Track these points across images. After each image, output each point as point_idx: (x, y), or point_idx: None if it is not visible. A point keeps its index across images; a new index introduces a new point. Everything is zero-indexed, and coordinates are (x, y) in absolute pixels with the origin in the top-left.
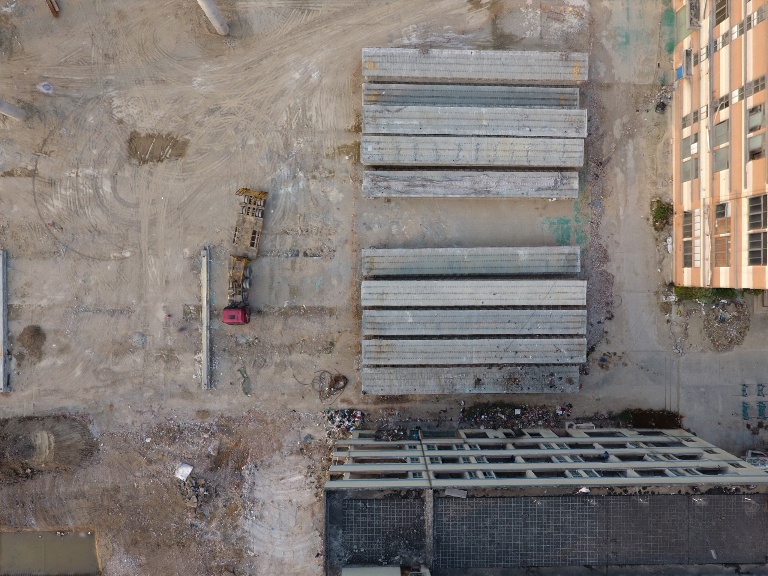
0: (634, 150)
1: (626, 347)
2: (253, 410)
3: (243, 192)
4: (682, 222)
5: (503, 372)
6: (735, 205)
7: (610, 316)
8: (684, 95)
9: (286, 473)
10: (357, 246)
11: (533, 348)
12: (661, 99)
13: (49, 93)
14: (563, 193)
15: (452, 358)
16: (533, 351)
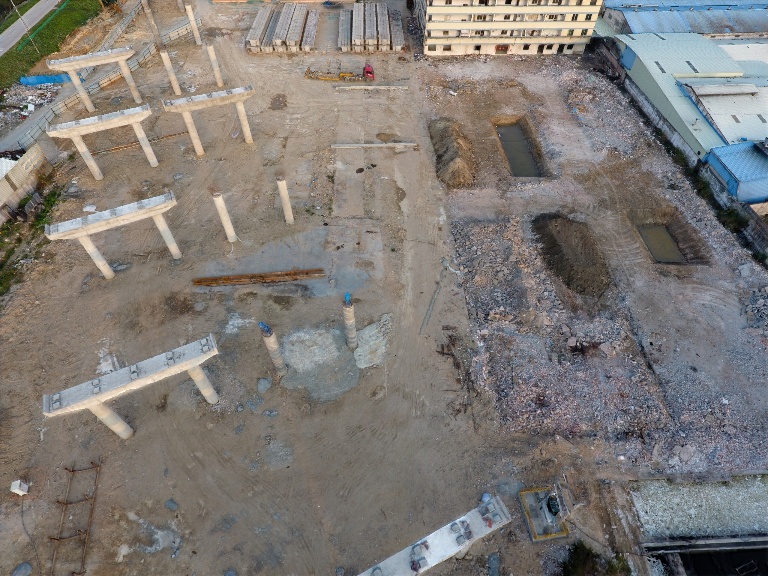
0: None
1: None
2: None
3: None
4: None
5: (392, 21)
6: None
7: None
8: None
9: (448, 70)
10: None
11: None
12: None
13: None
14: None
15: None
16: None
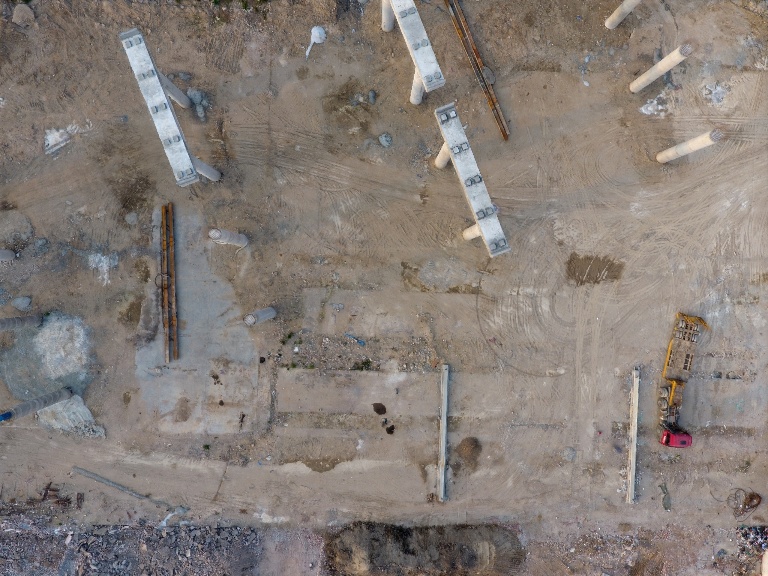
0: None
1: None
2: (671, 524)
3: None
4: None
5: None
6: None
7: None
8: None
9: None
10: None
11: None
12: None
13: None
14: None
15: None
16: None
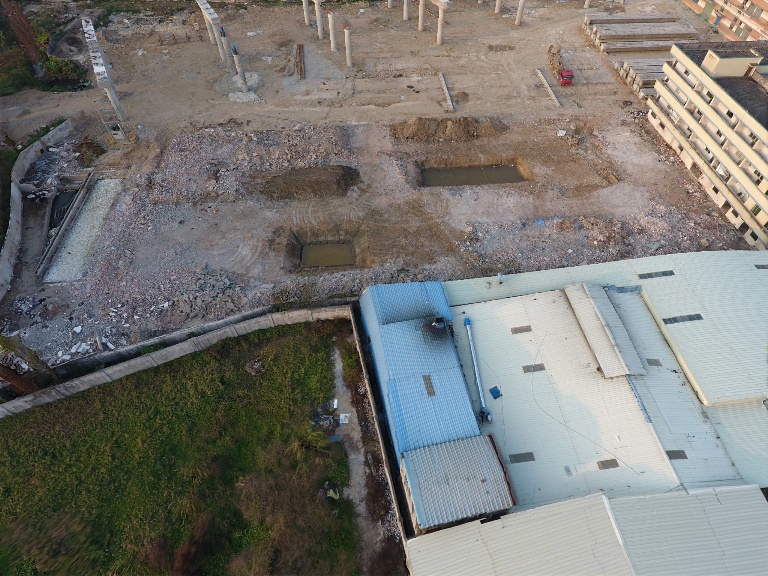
0: None
1: None
2: (587, 113)
3: None
4: None
5: None
6: None
7: None
8: (724, 23)
9: (619, 132)
10: None
11: None
12: None
13: None
14: None
15: None
16: None
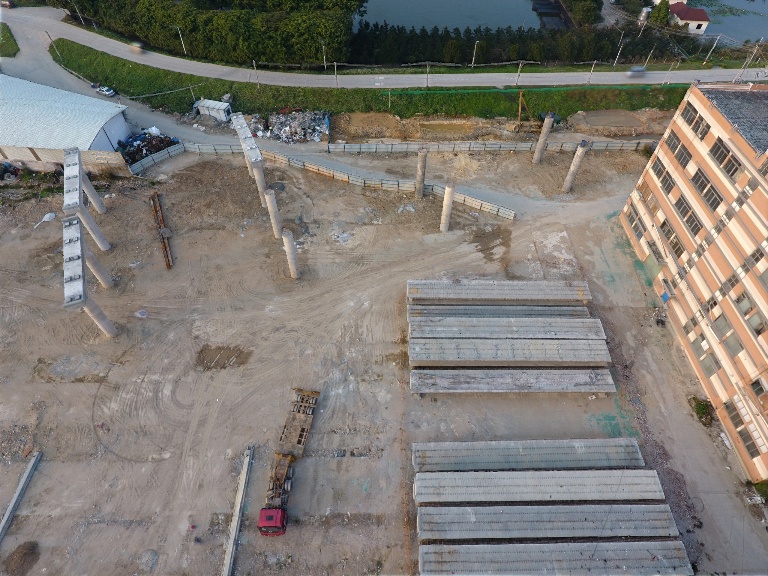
0: (652, 355)
1: (734, 565)
2: None
3: (298, 388)
4: (727, 414)
5: None
6: (767, 376)
7: (698, 523)
8: (676, 311)
9: None
10: (406, 445)
11: (623, 555)
12: (658, 317)
13: (143, 317)
14: (601, 388)
15: (530, 570)
16: (625, 559)
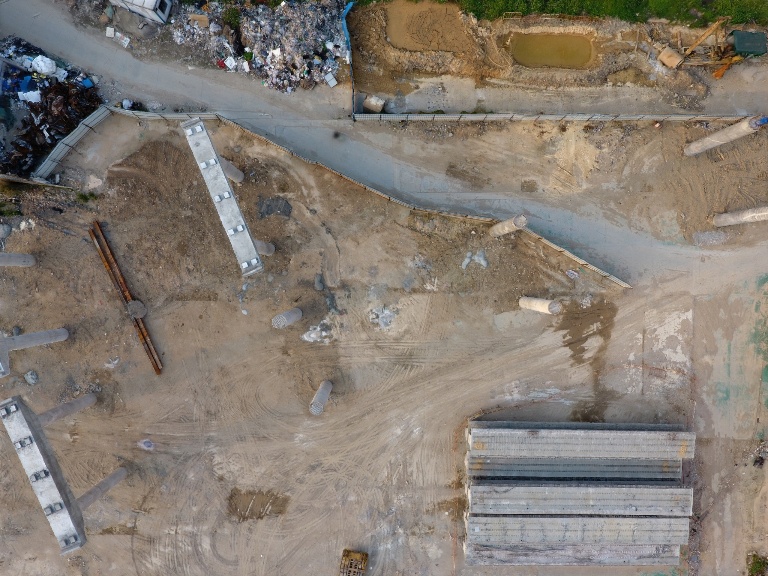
0: (732, 504)
1: None
2: None
3: (347, 565)
4: None
5: None
6: None
7: None
8: None
9: None
10: None
11: None
12: (760, 454)
13: (150, 450)
14: (664, 561)
15: None
16: None
